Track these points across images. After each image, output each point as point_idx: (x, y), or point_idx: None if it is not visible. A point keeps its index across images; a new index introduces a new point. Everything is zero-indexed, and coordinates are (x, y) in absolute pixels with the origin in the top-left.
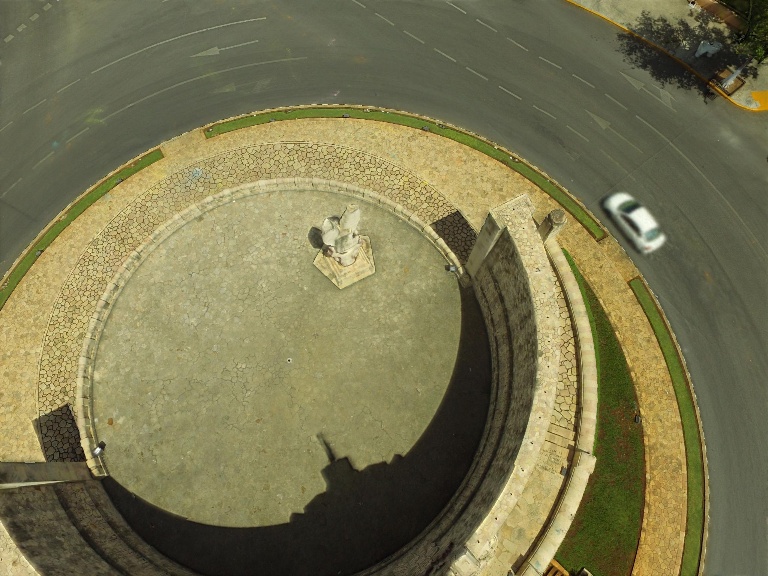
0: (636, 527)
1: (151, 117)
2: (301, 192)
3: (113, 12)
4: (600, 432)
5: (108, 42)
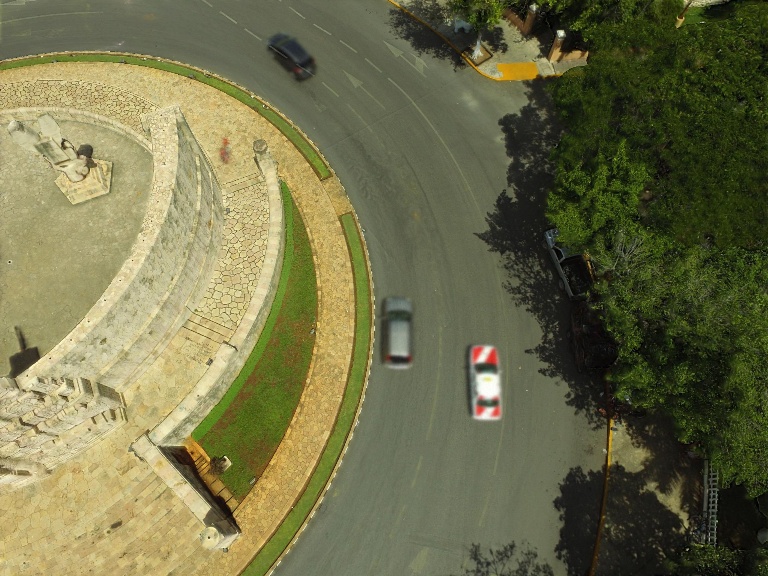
0: (285, 424)
1: None
2: (63, 122)
3: None
4: (275, 340)
5: None
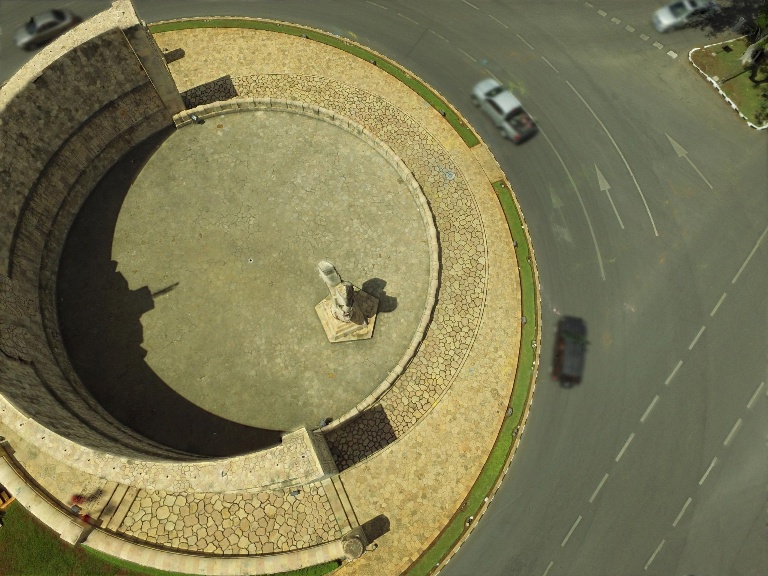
0: None
1: (517, 134)
2: (427, 272)
3: (645, 91)
4: (124, 571)
5: (606, 91)
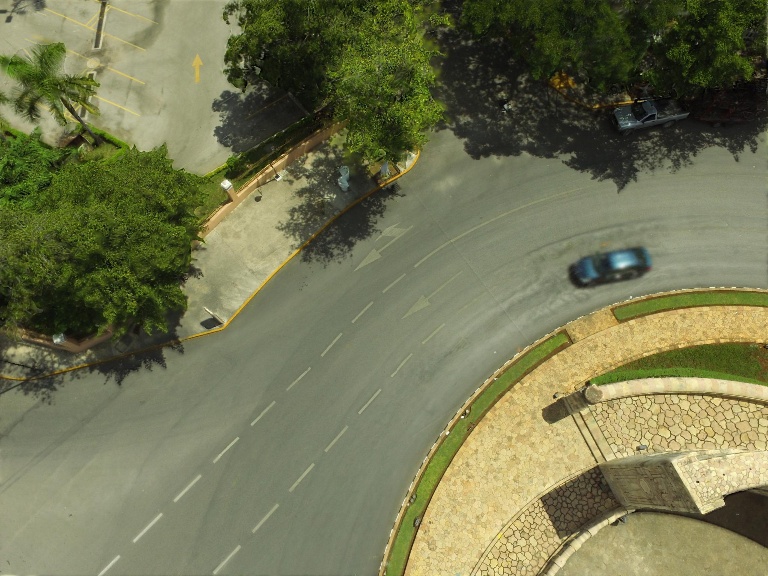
0: None
1: None
2: None
3: None
4: None
5: None
